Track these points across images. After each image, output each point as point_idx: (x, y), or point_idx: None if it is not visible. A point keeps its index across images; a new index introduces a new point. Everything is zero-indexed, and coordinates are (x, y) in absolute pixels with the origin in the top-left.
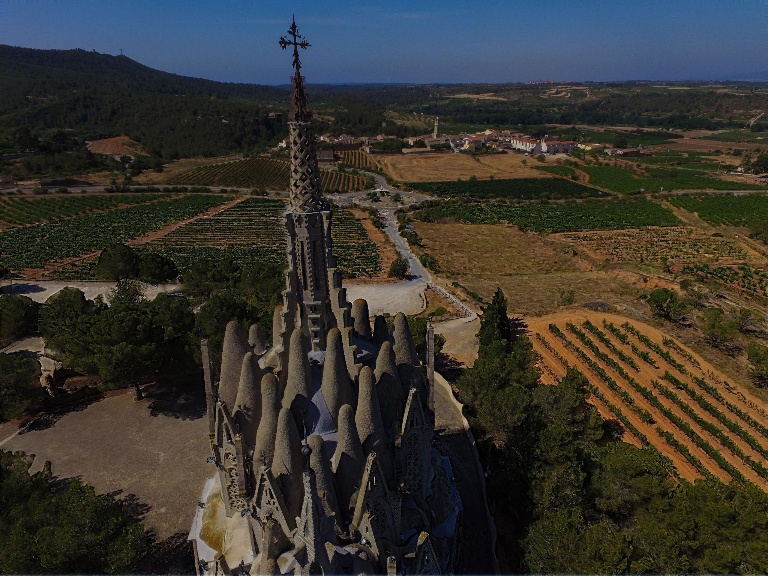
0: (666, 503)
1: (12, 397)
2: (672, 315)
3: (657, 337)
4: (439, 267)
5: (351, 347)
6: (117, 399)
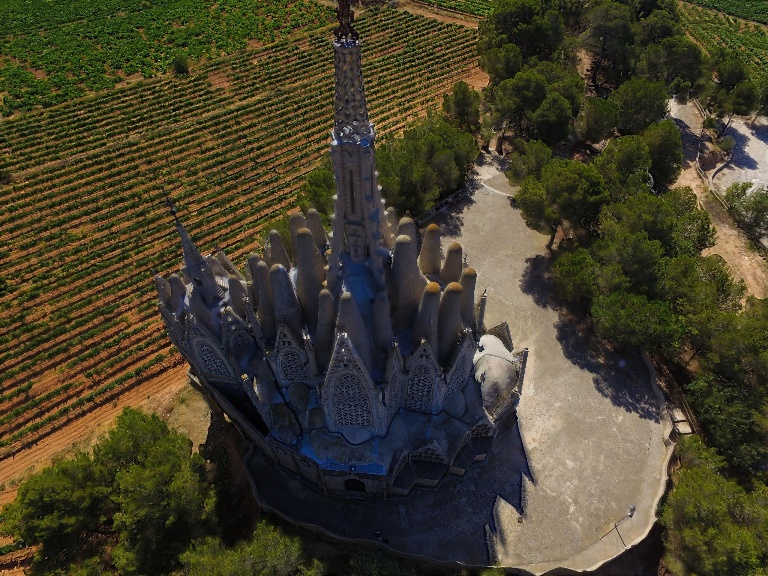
0: None
1: (526, 174)
2: None
3: None
4: None
5: (327, 265)
6: None
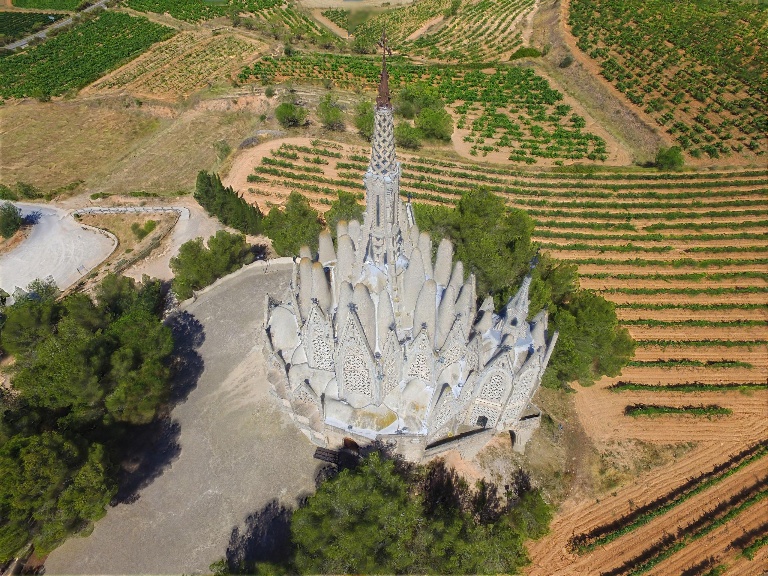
0: (466, 218)
1: None
2: (300, 122)
3: (304, 143)
4: (38, 191)
5: (411, 241)
6: (61, 547)
